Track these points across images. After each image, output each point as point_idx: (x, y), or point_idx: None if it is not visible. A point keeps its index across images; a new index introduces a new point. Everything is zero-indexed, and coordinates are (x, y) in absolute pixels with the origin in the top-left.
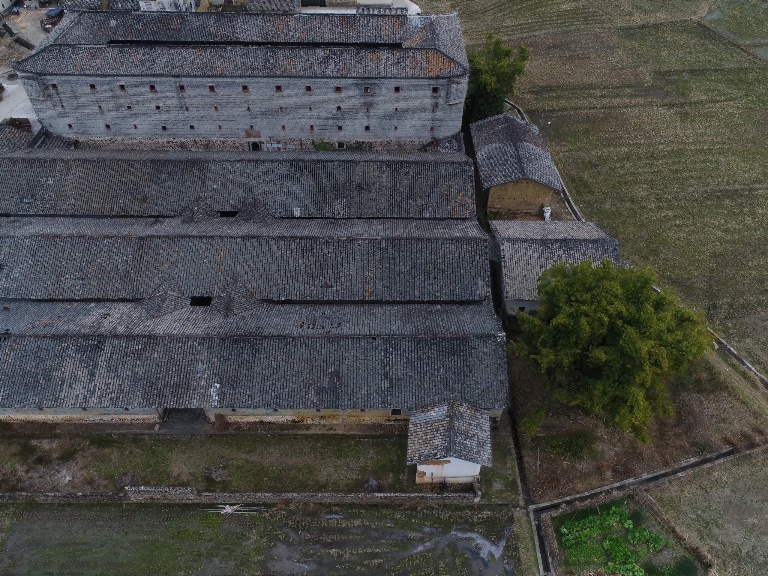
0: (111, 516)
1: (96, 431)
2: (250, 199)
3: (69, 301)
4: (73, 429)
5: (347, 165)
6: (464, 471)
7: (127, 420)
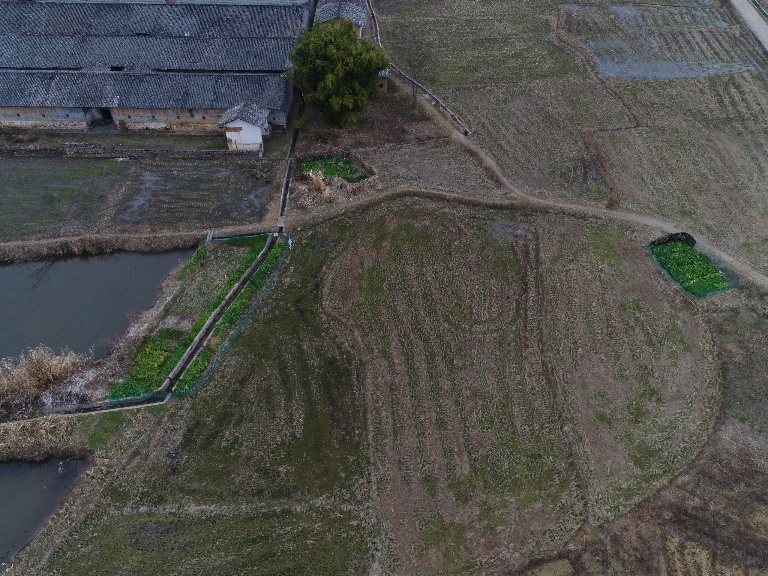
0: (55, 161)
1: (51, 132)
2: (158, 27)
3: (38, 69)
4: (37, 131)
5: (222, 8)
6: (253, 138)
7: (69, 126)
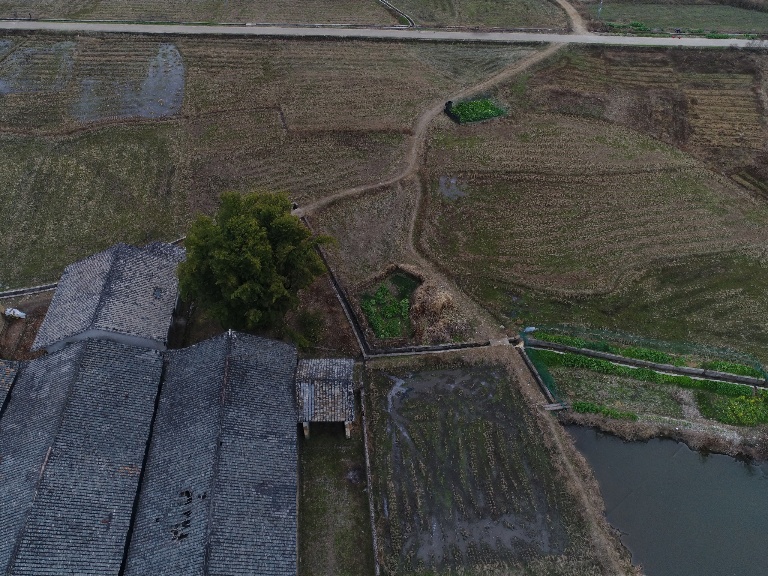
0: None
1: None
2: None
3: None
4: None
5: None
6: None
7: None
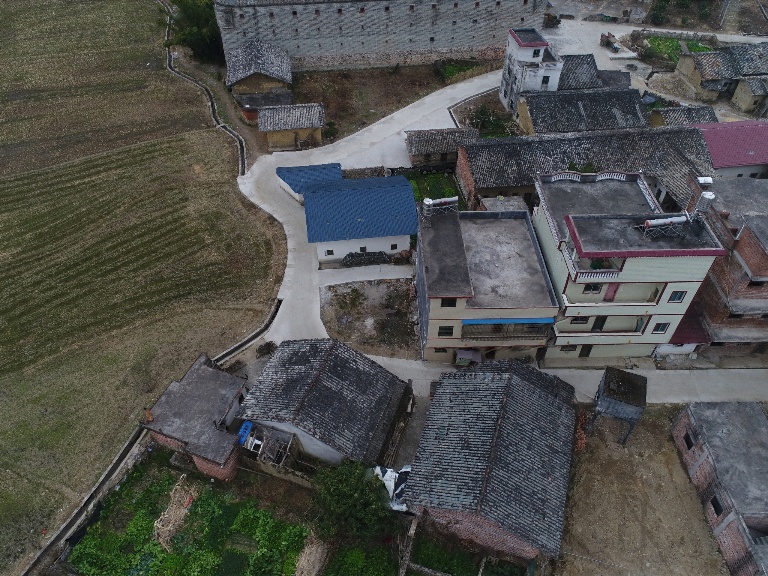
0: None
1: None
2: None
3: None
4: None
5: None
6: None
7: None
